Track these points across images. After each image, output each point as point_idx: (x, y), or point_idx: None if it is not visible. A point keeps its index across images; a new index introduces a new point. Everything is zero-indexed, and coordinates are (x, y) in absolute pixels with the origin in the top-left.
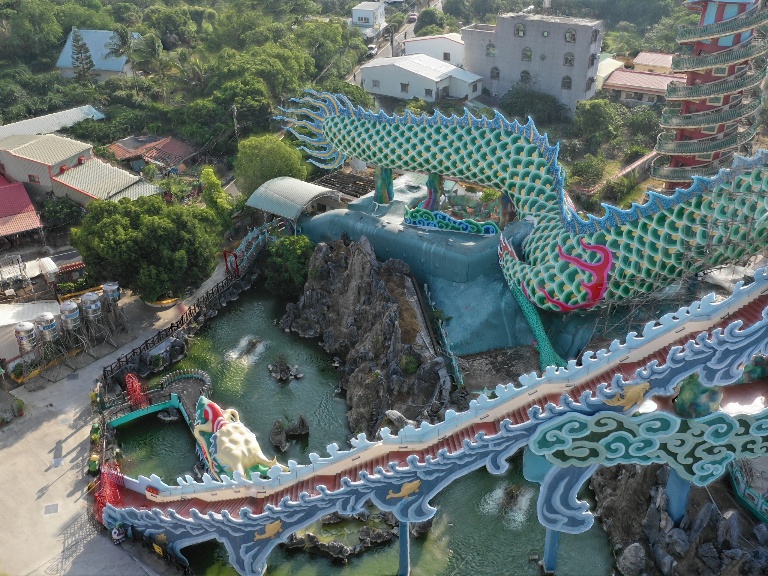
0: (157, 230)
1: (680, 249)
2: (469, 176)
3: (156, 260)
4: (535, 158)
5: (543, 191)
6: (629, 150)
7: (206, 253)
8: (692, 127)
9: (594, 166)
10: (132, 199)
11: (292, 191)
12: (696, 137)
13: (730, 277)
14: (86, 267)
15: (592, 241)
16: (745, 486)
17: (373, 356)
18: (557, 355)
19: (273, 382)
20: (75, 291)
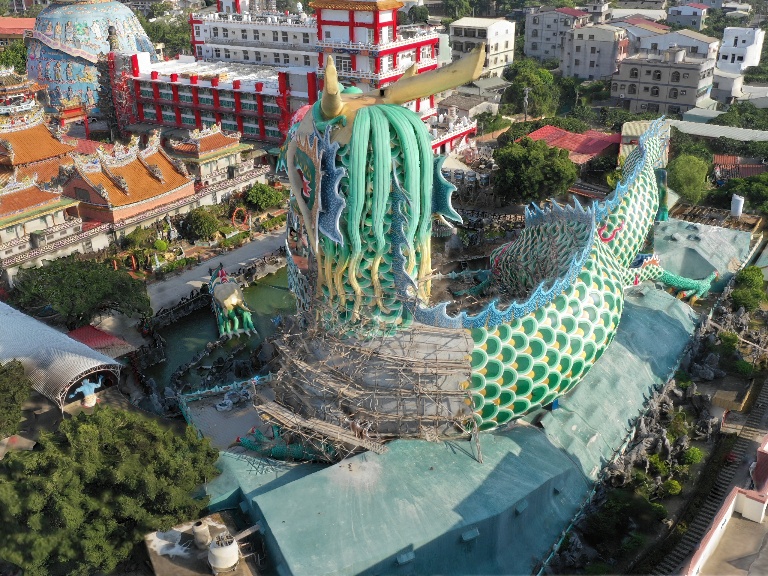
0: None
1: None
2: None
3: None
4: None
5: None
6: None
7: None
8: None
9: None
10: None
11: None
12: None
13: None
14: None
15: None
16: None
17: None
18: None
19: None
20: None
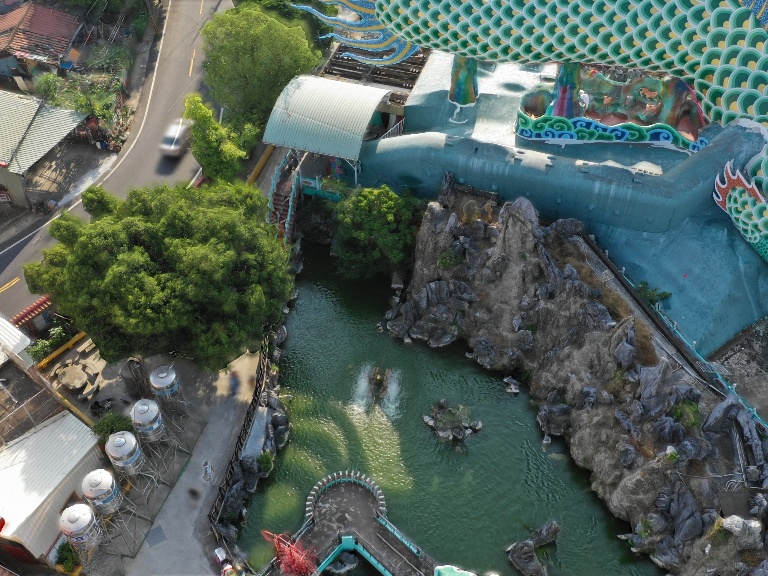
0: (214, 269)
1: None
2: (636, 64)
3: (214, 308)
4: (748, 29)
5: (763, 79)
6: None
7: (281, 271)
8: None
9: None
10: (48, 147)
11: (332, 109)
12: None
13: None
14: (53, 306)
15: None
16: None
17: (612, 398)
18: None
19: (447, 447)
20: (52, 350)
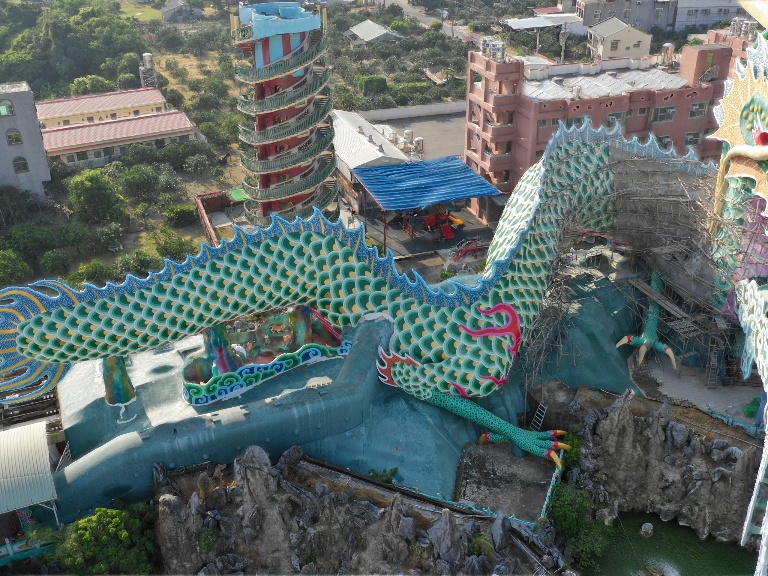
0: None
1: (546, 273)
2: (271, 305)
3: None
4: (338, 250)
5: (366, 281)
6: (172, 213)
7: None
8: (300, 164)
9: (183, 242)
10: None
11: None
12: (297, 173)
13: None
14: None
15: (490, 304)
16: (757, 428)
17: (420, 571)
18: (527, 431)
19: None
20: None
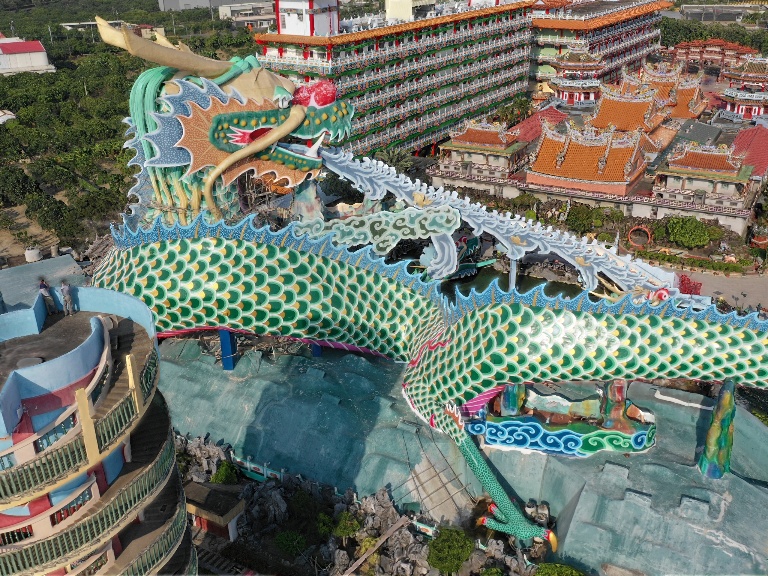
0: None
1: None
2: None
3: None
4: None
5: None
6: None
7: None
8: None
9: None
10: None
11: None
12: None
13: (270, 369)
14: None
15: None
16: None
17: None
18: None
19: None
20: None
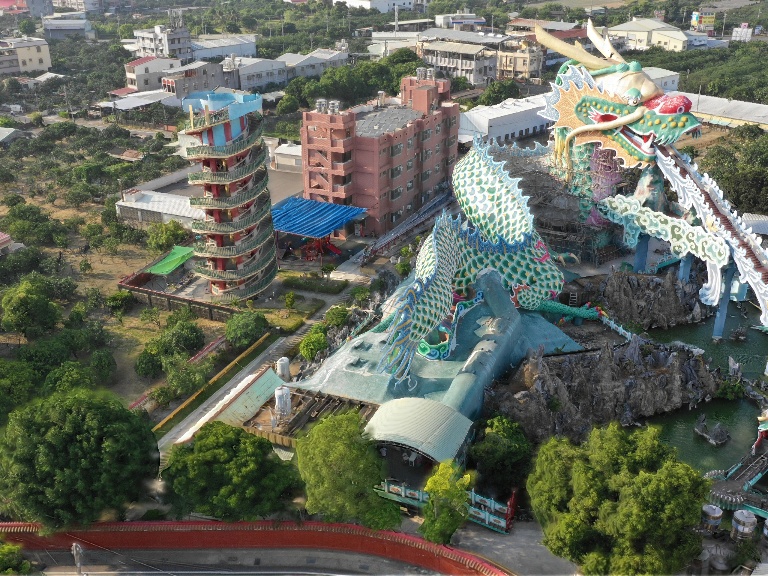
0: None
1: None
2: None
3: None
4: None
5: None
6: (118, 301)
7: None
8: None
9: None
10: None
11: (429, 419)
12: None
13: None
14: None
15: None
16: None
17: None
18: None
19: None
20: None
